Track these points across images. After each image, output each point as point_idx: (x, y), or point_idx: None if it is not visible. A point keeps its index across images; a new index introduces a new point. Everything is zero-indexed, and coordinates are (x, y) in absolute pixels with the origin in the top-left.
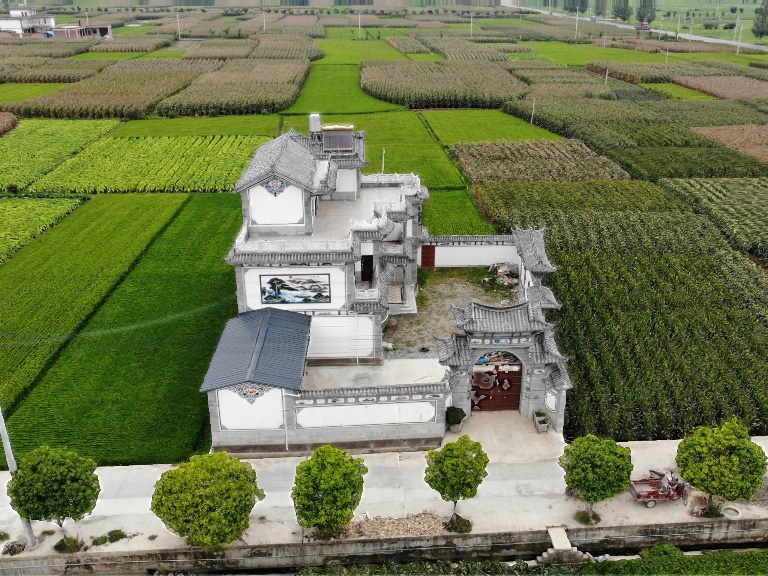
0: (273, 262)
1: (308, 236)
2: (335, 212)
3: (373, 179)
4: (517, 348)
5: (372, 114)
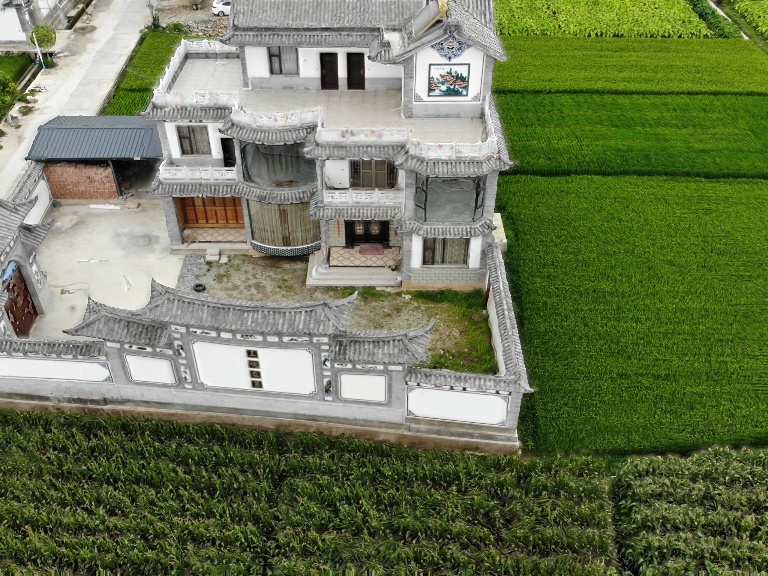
0: None
1: (242, 87)
2: (343, 101)
3: None
4: None
5: None
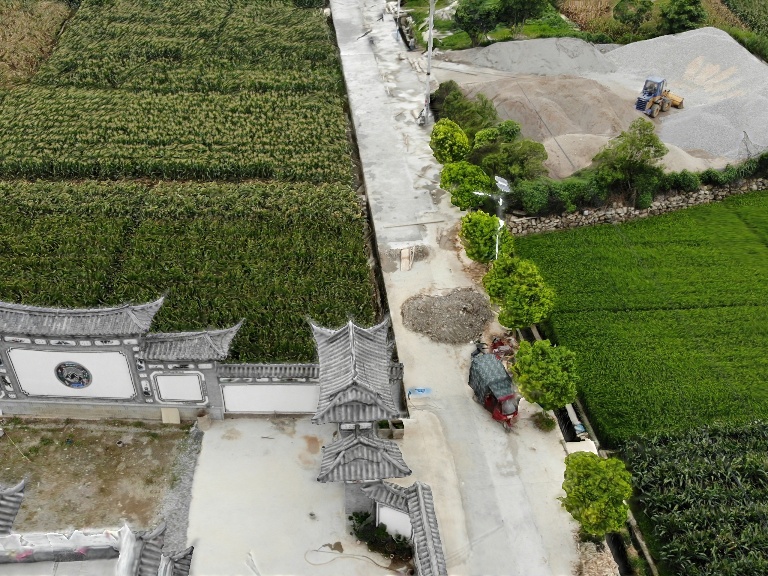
0: None
1: None
2: None
3: None
4: None
5: None
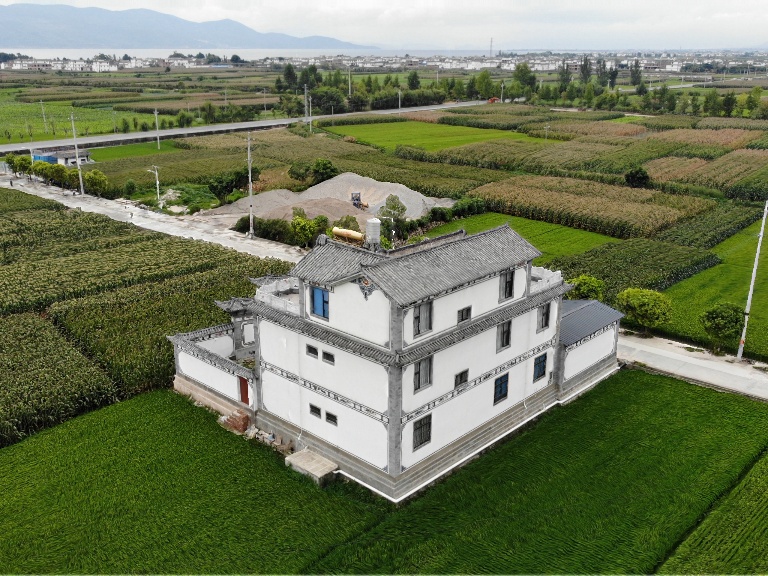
0: None
1: None
2: None
3: (291, 308)
4: None
5: None
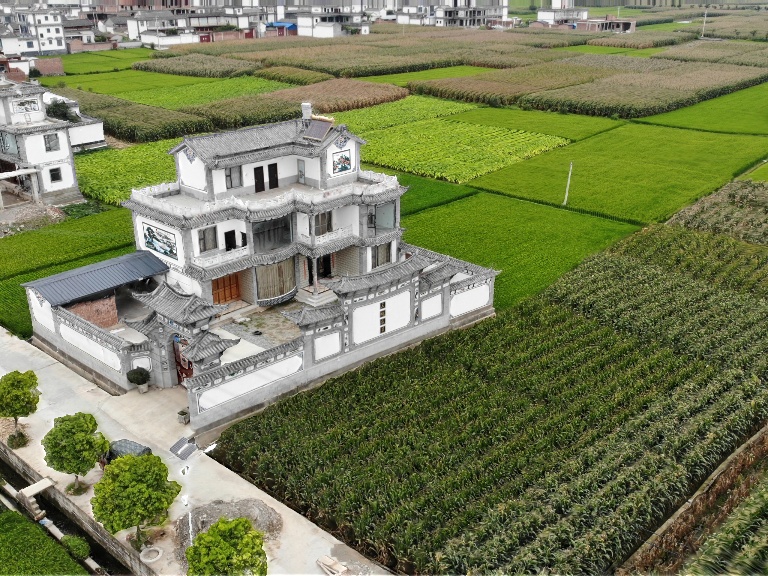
0: (142, 213)
1: None
2: (278, 193)
3: (367, 175)
4: (185, 336)
5: (727, 135)
